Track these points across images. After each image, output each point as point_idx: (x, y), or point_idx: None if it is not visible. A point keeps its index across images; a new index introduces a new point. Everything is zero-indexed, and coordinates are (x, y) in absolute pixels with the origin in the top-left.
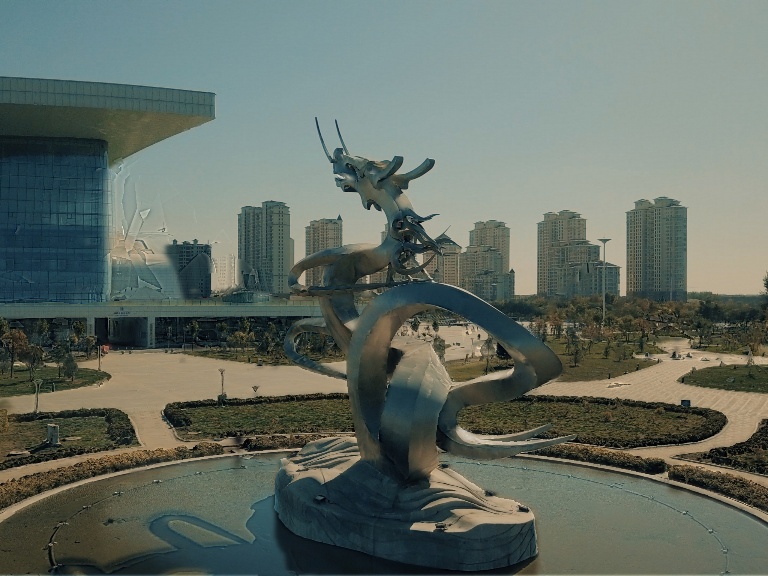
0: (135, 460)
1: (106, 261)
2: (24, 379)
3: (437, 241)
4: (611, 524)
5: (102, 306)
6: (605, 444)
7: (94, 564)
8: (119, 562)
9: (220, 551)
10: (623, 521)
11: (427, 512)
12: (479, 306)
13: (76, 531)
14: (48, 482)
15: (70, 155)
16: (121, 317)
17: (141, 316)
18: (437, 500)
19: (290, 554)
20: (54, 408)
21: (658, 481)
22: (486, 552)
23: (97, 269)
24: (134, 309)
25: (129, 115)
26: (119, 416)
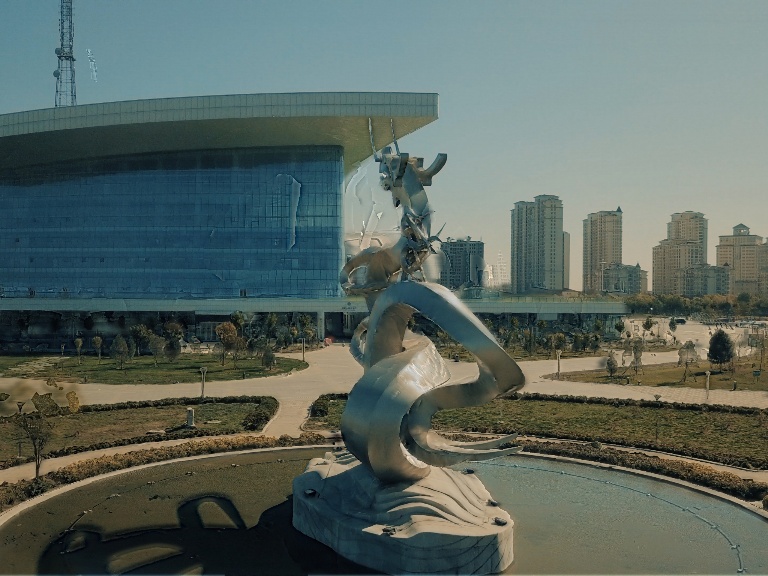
0: (232, 445)
1: (341, 259)
2: (232, 367)
3: (428, 239)
4: (660, 551)
5: (331, 301)
6: (733, 463)
7: (101, 532)
8: (122, 533)
9: (214, 533)
10: (670, 549)
11: (392, 515)
12: (444, 306)
13: (122, 503)
14: (140, 458)
15: (310, 161)
16: (357, 312)
17: (367, 311)
18: (405, 504)
19: (283, 543)
20: (228, 394)
21: (747, 509)
22: (429, 562)
23: (332, 267)
24: (361, 304)
25: (357, 120)
26: (266, 404)
